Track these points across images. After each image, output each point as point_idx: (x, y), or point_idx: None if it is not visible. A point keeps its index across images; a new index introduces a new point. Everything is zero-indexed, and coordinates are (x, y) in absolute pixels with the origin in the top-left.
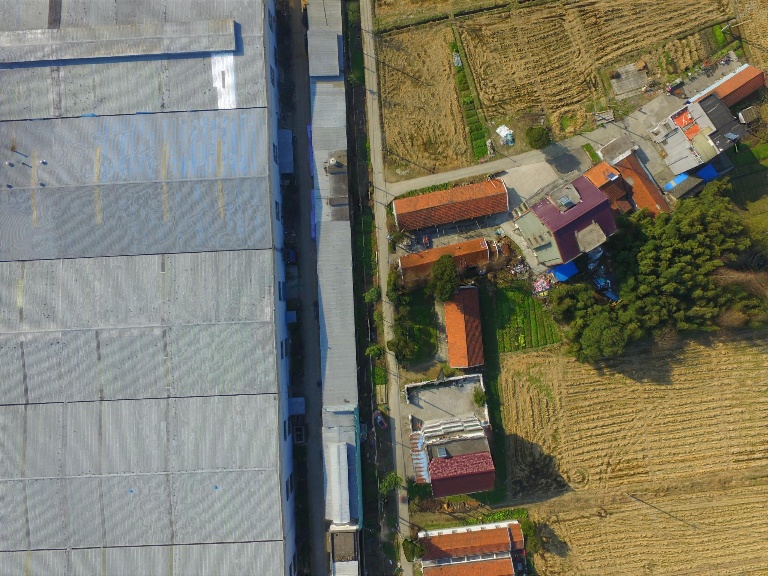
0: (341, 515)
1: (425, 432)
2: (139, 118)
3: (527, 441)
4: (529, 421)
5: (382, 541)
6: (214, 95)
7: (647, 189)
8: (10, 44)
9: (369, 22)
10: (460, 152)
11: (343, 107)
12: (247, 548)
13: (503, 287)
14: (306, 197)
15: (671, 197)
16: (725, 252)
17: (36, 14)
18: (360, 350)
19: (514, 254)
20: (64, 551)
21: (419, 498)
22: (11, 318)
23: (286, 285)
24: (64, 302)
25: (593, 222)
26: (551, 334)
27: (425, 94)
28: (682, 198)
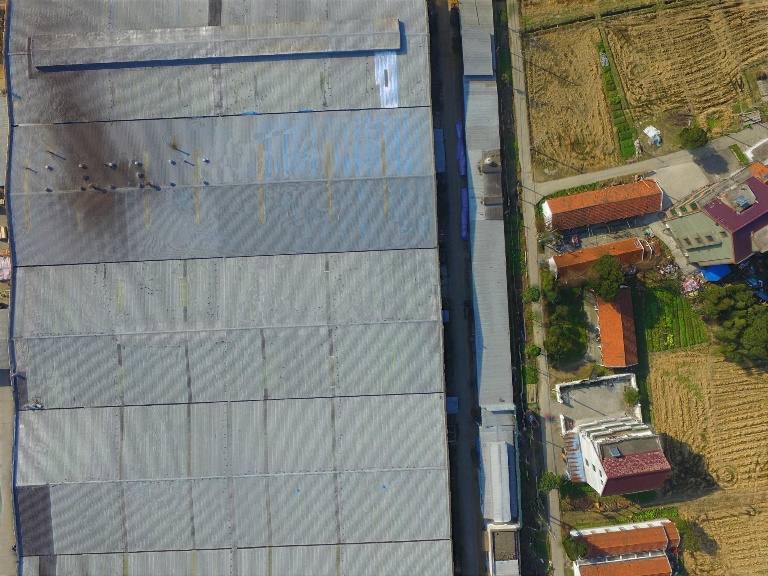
0: (502, 514)
1: (589, 431)
2: (301, 116)
3: (676, 440)
4: (678, 420)
5: (533, 540)
6: (377, 94)
7: None
8: (173, 41)
9: (516, 22)
10: (608, 152)
11: (496, 107)
12: (414, 547)
13: (652, 287)
14: (455, 196)
15: None
16: None
17: (195, 11)
18: (512, 349)
19: (663, 254)
20: (229, 550)
21: (570, 497)
22: (175, 317)
23: None
24: (228, 301)
25: None
26: (699, 334)
27: (572, 94)
28: None
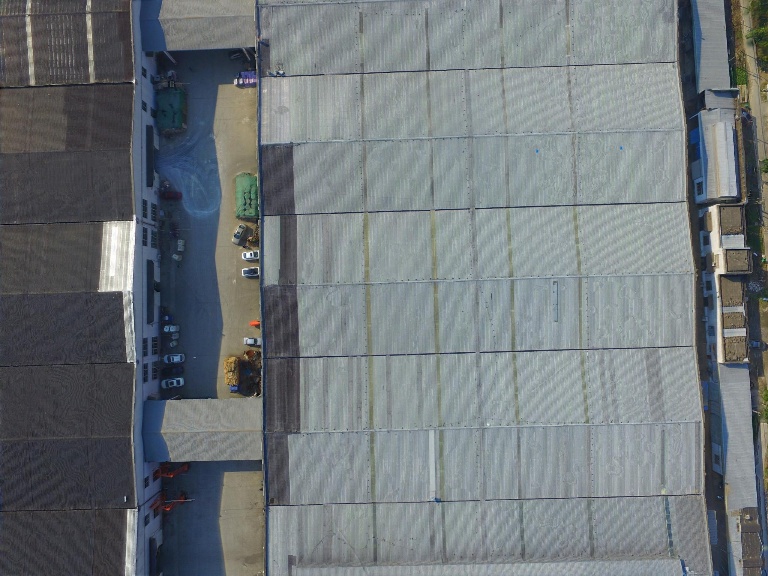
0: (729, 188)
1: None
2: None
3: None
4: None
5: None
6: None
7: None
8: None
9: None
10: None
11: None
12: (649, 209)
13: None
14: None
15: None
16: None
17: None
18: None
19: None
20: (467, 211)
21: None
22: None
23: None
24: None
25: None
26: None
27: None
28: None
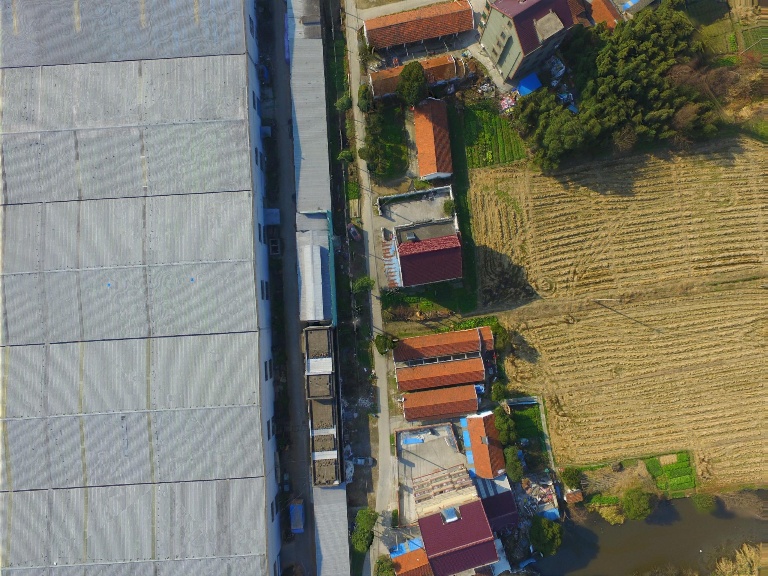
0: (315, 312)
1: None
2: None
3: (496, 252)
4: (498, 233)
5: (356, 350)
6: None
7: (605, 5)
8: None
9: None
10: None
11: None
12: (222, 339)
13: (471, 106)
14: (280, 23)
15: (629, 15)
16: (679, 55)
17: None
18: (333, 165)
19: (481, 74)
20: (42, 346)
21: (392, 308)
22: None
23: (261, 106)
24: (43, 105)
25: (551, 11)
26: (518, 150)
27: None
28: (638, 13)
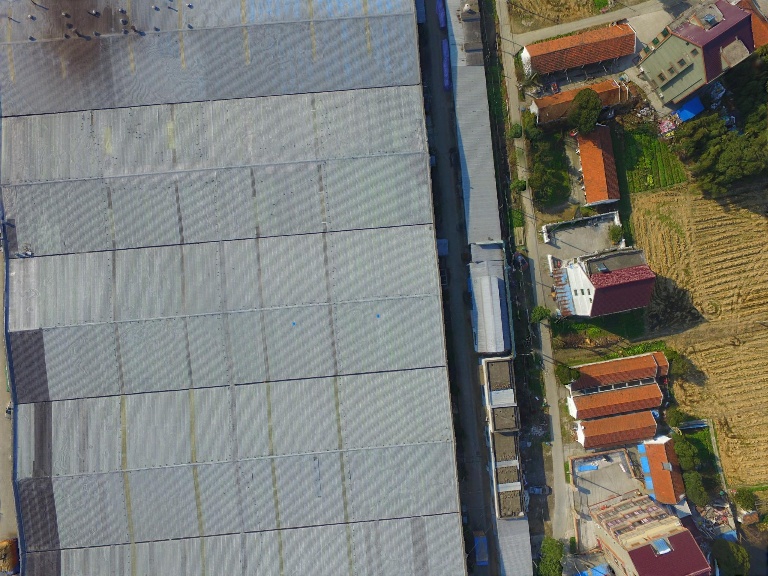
0: (496, 344)
1: None
2: None
3: (661, 276)
4: (662, 257)
5: (527, 378)
6: None
7: (766, 27)
8: None
9: None
10: (581, 4)
11: None
12: (410, 375)
13: (630, 130)
14: (436, 49)
15: None
16: None
17: None
18: None
19: (639, 98)
20: (227, 387)
21: (561, 335)
22: (164, 159)
23: None
24: (217, 141)
25: (736, 38)
26: (678, 174)
27: None
28: None
